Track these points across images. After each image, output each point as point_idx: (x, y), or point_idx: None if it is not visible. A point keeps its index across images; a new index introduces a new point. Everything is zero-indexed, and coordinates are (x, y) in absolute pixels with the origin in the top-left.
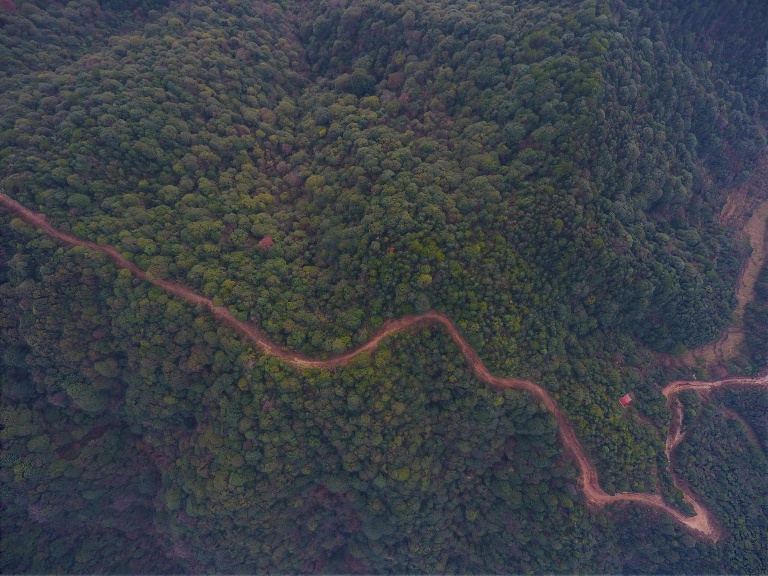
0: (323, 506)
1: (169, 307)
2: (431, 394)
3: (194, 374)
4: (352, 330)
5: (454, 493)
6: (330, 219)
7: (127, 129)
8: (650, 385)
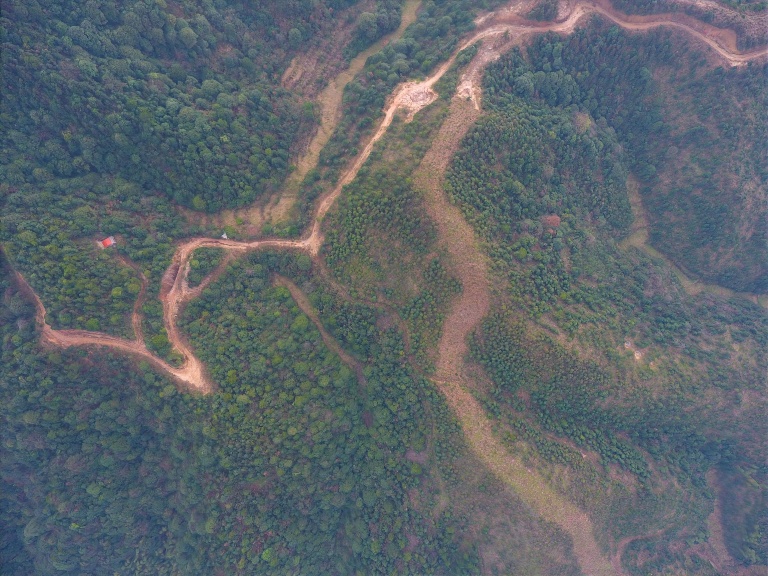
0: None
1: None
2: None
3: None
4: None
5: None
6: None
7: None
8: (151, 233)
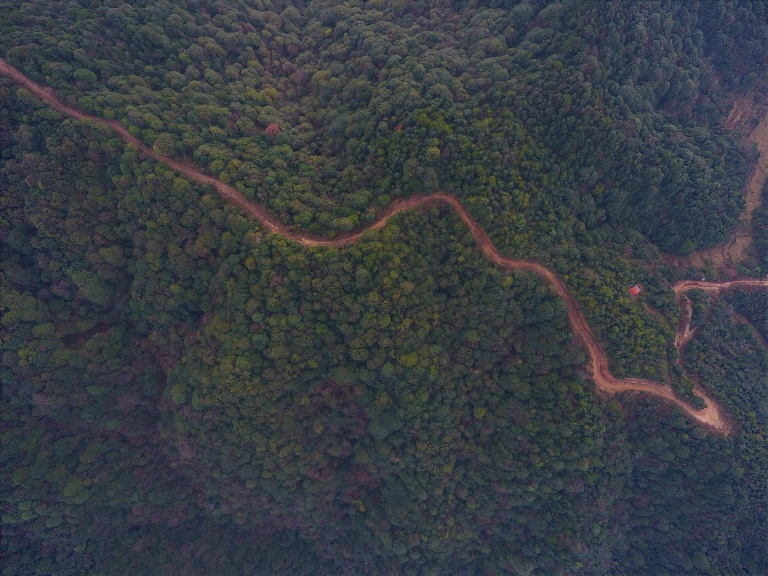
0: (330, 408)
1: (176, 182)
2: (439, 279)
3: (200, 260)
4: (360, 210)
5: (462, 390)
6: (337, 109)
7: (133, 13)
8: (659, 279)
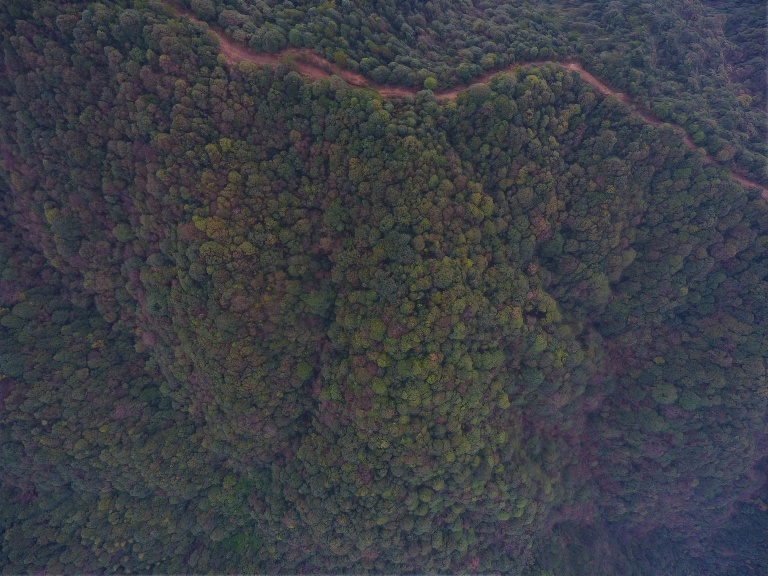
0: None
1: (737, 187)
2: None
3: (718, 263)
4: None
5: None
6: None
7: None
8: None
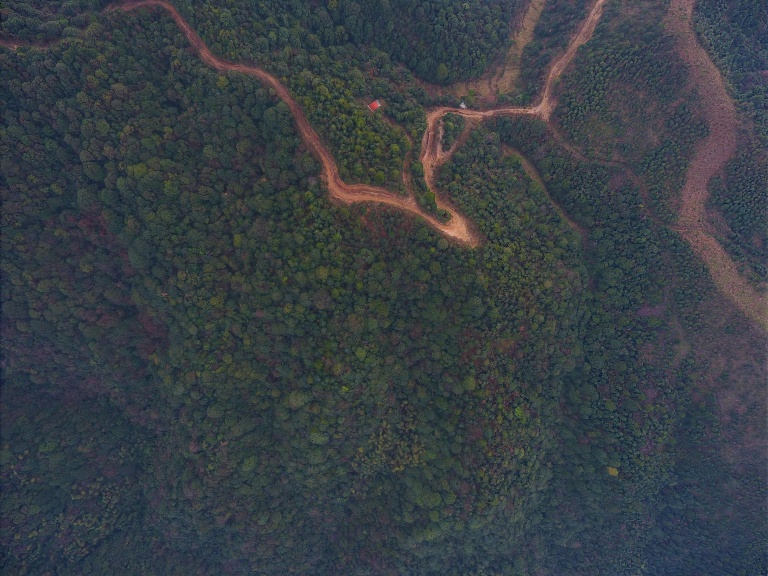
0: (95, 245)
1: None
2: (166, 91)
3: None
4: (71, 15)
5: (217, 216)
6: None
7: None
8: (407, 99)
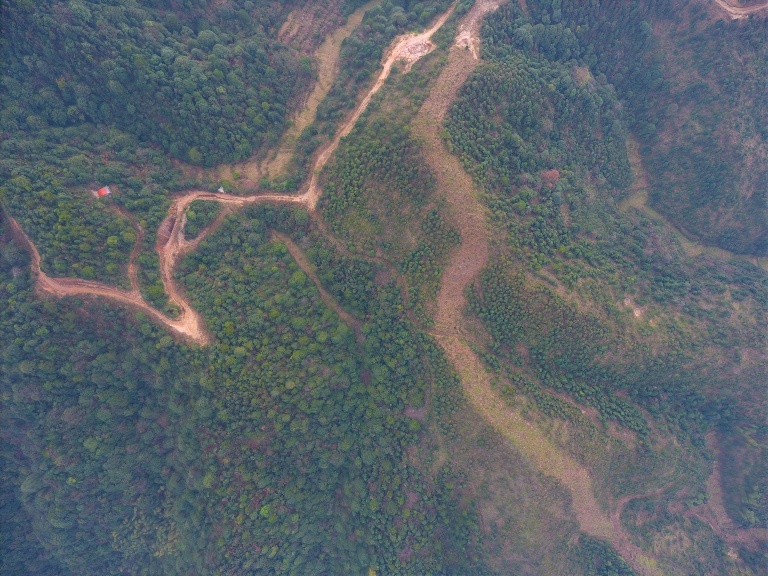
0: None
1: None
2: None
3: None
4: None
5: None
6: None
7: None
8: (147, 184)
